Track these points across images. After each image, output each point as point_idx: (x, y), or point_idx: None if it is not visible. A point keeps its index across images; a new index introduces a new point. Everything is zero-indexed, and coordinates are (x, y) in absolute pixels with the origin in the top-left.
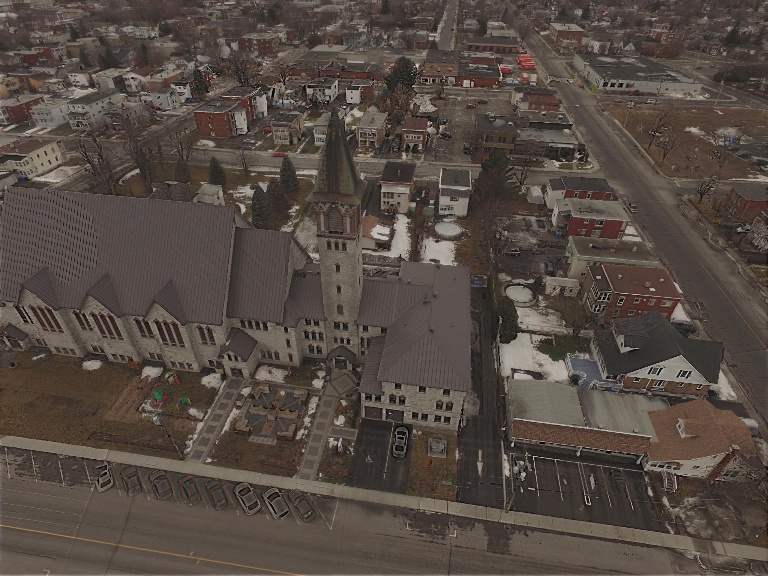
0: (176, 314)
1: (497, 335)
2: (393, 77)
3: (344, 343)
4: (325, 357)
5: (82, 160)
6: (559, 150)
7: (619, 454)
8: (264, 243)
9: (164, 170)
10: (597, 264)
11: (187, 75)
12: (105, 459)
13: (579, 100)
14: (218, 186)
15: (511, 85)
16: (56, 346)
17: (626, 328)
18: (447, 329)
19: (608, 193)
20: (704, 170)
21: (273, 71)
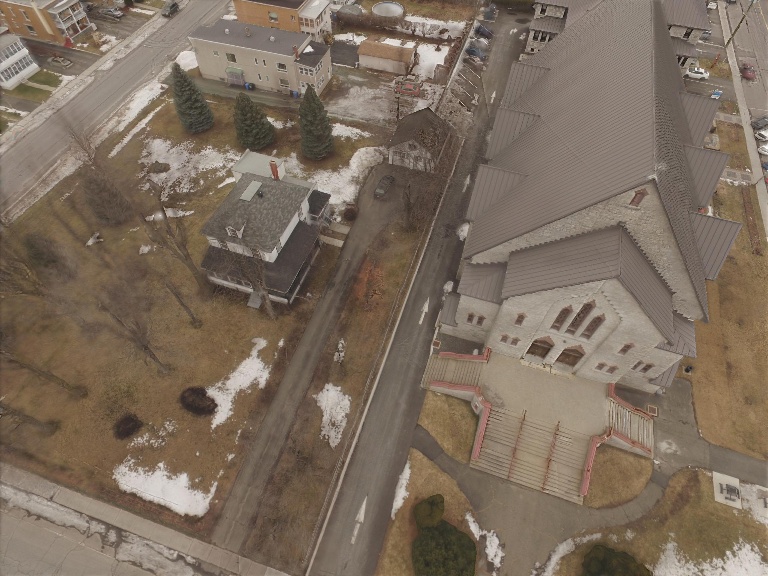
0: None
1: None
2: None
3: None
4: None
5: None
6: None
7: None
8: None
9: None
10: None
11: None
12: None
13: None
14: (247, 153)
15: None
16: None
17: None
18: None
19: None
20: None
21: None
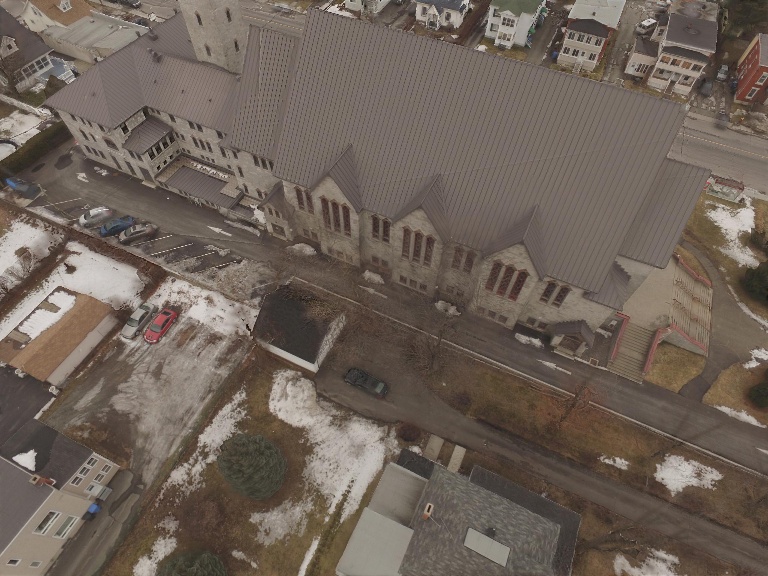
0: None
1: None
2: None
3: None
4: None
5: None
6: None
7: None
8: None
9: None
10: None
11: None
12: None
13: None
14: (347, 575)
15: None
16: None
17: None
18: None
19: None
20: None
21: None
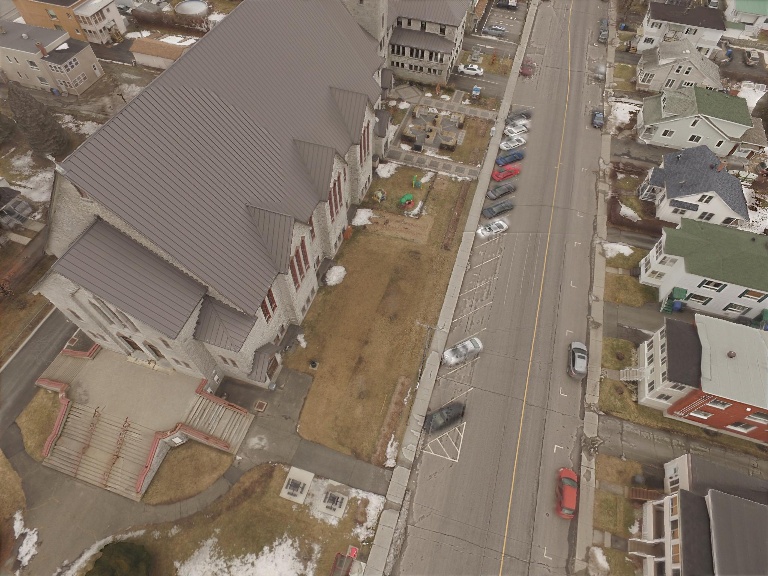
0: None
1: None
2: None
3: None
4: None
5: None
6: None
7: None
8: None
9: None
10: None
11: None
12: (474, 232)
13: None
14: None
15: None
16: (303, 305)
17: None
18: None
19: None
20: None
21: None
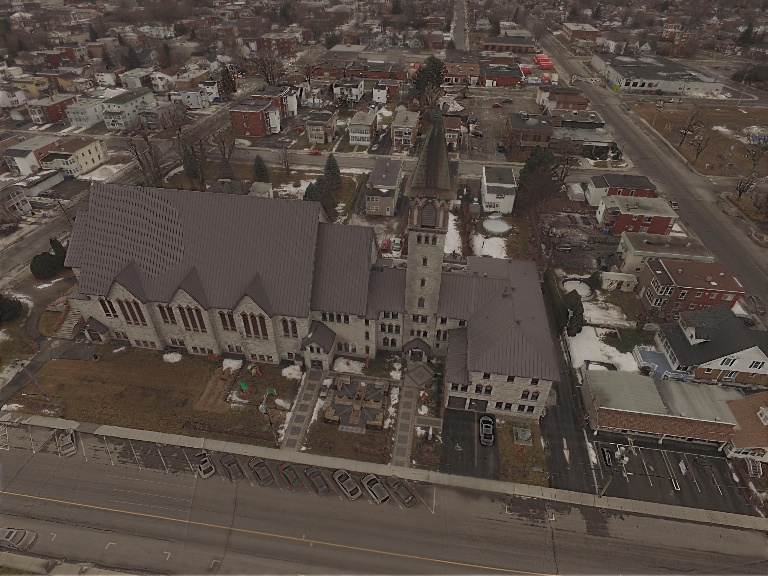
0: (264, 307)
1: (566, 328)
2: (422, 76)
3: (420, 336)
4: (399, 350)
5: (123, 159)
6: (593, 148)
7: (700, 442)
8: (347, 238)
9: (205, 168)
10: (653, 259)
11: (214, 75)
12: (203, 447)
13: (603, 99)
14: (268, 184)
15: (533, 84)
16: (137, 339)
17: (695, 321)
18: (529, 321)
19: (651, 190)
20: (737, 168)
21: (298, 71)
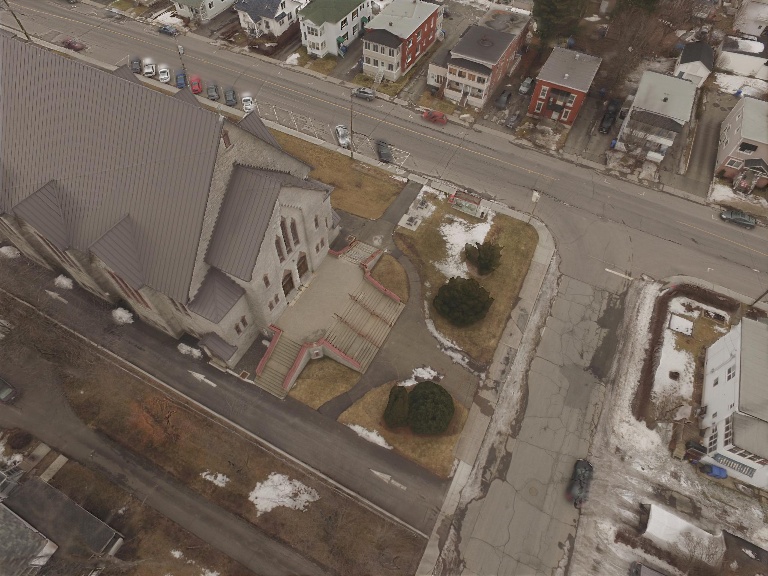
0: None
1: None
2: None
3: None
4: None
5: None
6: None
7: None
8: None
9: None
10: None
11: None
12: (246, 113)
13: None
14: None
15: None
16: None
17: None
18: None
19: None
20: None
21: None
